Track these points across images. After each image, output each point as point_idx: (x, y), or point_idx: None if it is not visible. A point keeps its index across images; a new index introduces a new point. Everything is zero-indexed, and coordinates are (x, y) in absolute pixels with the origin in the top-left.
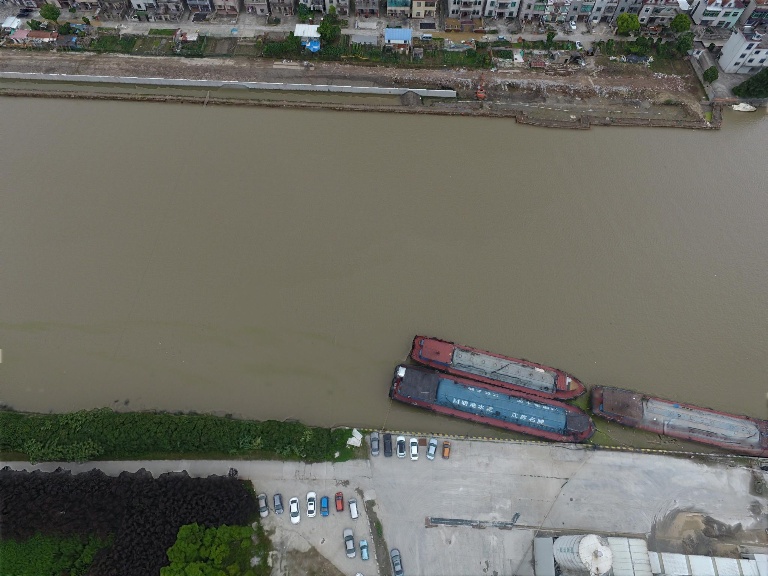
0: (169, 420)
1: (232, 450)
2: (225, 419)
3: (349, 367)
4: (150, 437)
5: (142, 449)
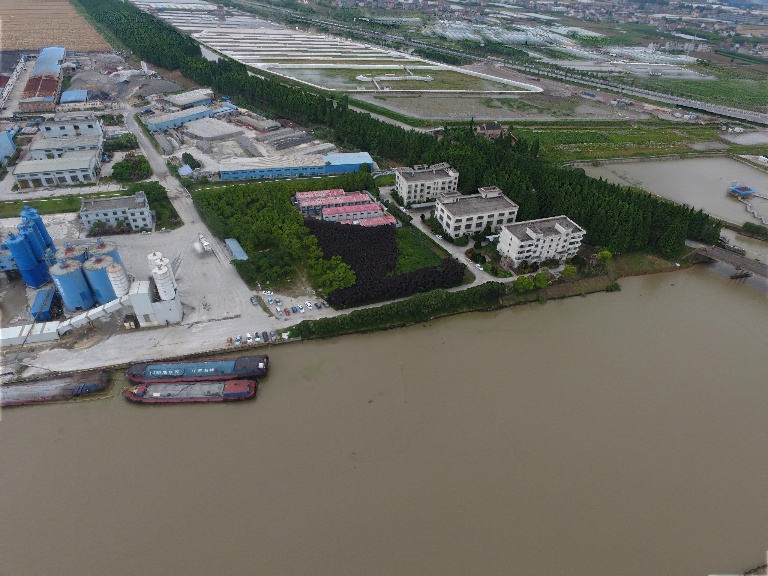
0: (388, 311)
1: None
2: (360, 320)
3: (300, 369)
4: None
5: None
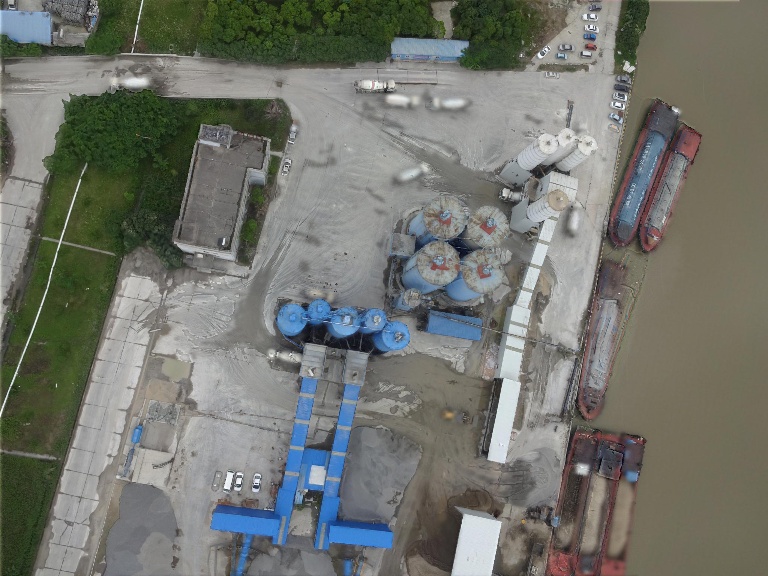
0: None
1: None
2: None
3: (678, 77)
4: None
5: None
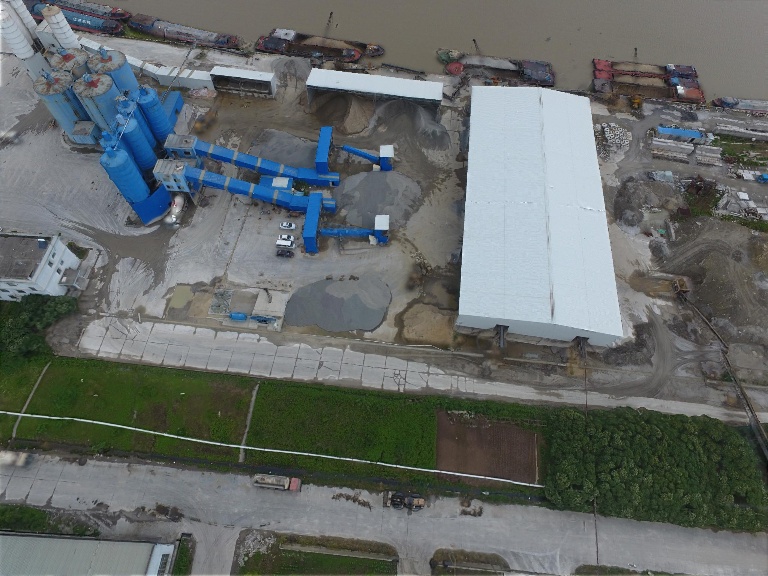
0: None
1: None
2: None
3: None
4: None
5: None
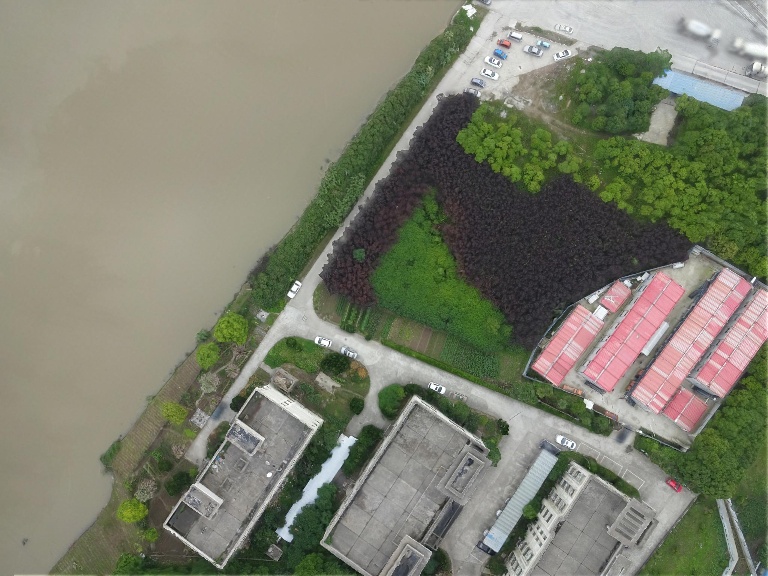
0: (374, 120)
1: (422, 92)
2: (397, 85)
3: None
4: (378, 137)
5: (379, 154)
